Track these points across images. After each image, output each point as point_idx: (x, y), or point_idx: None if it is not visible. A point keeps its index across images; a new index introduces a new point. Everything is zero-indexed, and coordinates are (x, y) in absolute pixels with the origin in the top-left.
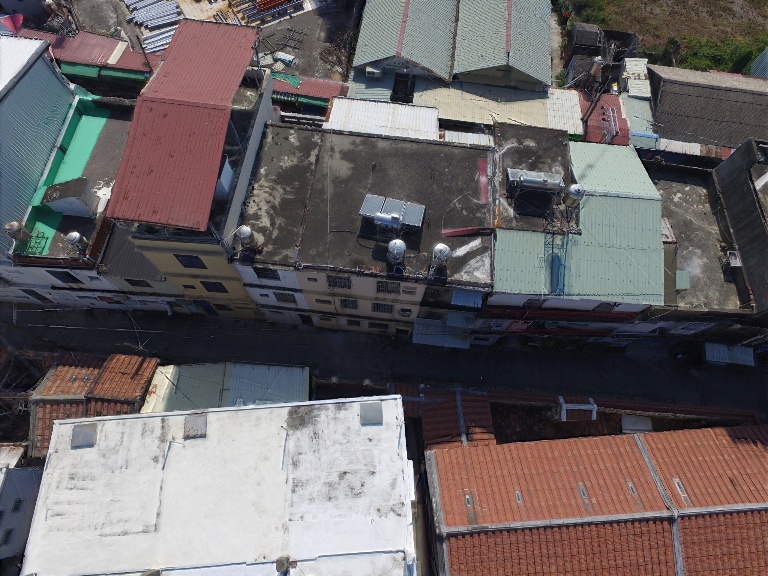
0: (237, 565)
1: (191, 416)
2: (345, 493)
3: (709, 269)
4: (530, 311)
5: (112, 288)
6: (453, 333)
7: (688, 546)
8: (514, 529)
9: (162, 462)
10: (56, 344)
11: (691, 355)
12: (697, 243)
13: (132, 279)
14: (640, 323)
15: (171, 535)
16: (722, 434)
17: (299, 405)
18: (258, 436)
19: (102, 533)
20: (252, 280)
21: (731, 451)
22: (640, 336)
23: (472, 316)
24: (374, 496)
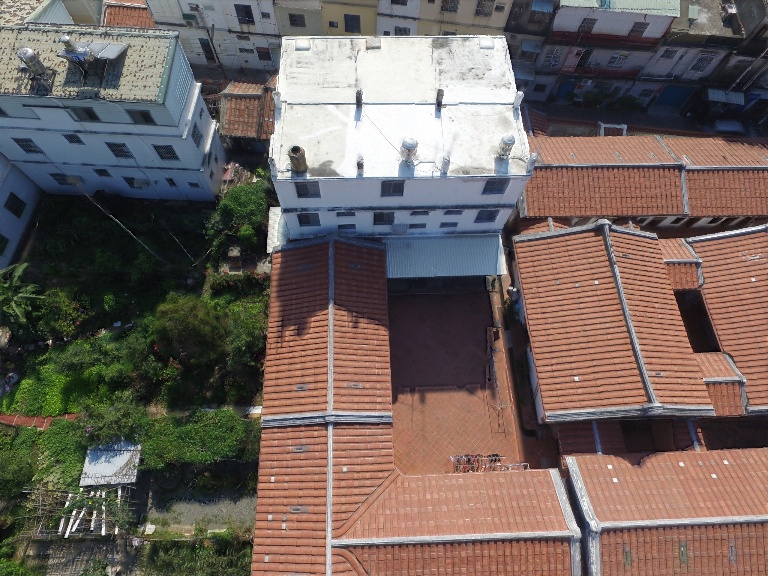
0: (409, 105)
1: (370, 38)
2: (473, 78)
3: (713, 20)
4: (583, 32)
5: (273, 32)
6: (523, 69)
7: (692, 191)
8: (571, 167)
9: (354, 59)
10: (226, 78)
11: (697, 114)
12: (704, 5)
13: (295, 13)
14: (661, 58)
15: (366, 89)
16: (719, 140)
17: (439, 37)
18: (414, 50)
19: (323, 86)
20: (385, 8)
21: (725, 146)
22: (660, 80)
23: (540, 44)
24: (492, 79)
